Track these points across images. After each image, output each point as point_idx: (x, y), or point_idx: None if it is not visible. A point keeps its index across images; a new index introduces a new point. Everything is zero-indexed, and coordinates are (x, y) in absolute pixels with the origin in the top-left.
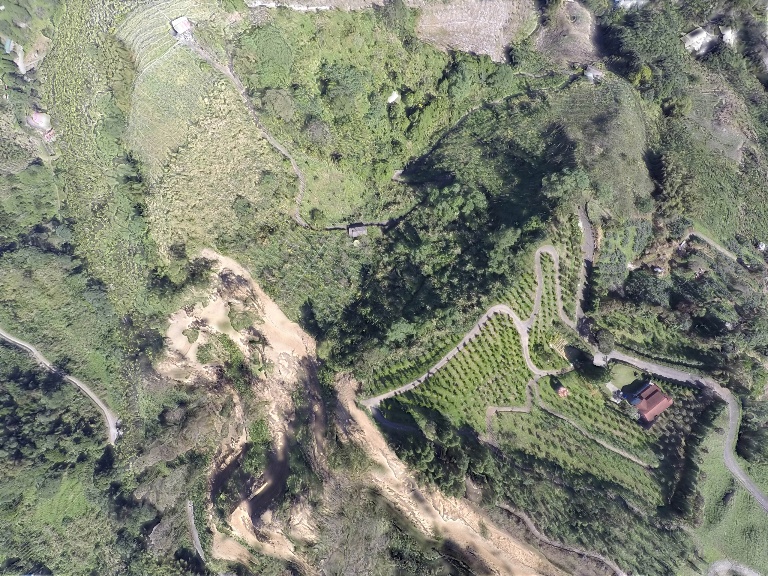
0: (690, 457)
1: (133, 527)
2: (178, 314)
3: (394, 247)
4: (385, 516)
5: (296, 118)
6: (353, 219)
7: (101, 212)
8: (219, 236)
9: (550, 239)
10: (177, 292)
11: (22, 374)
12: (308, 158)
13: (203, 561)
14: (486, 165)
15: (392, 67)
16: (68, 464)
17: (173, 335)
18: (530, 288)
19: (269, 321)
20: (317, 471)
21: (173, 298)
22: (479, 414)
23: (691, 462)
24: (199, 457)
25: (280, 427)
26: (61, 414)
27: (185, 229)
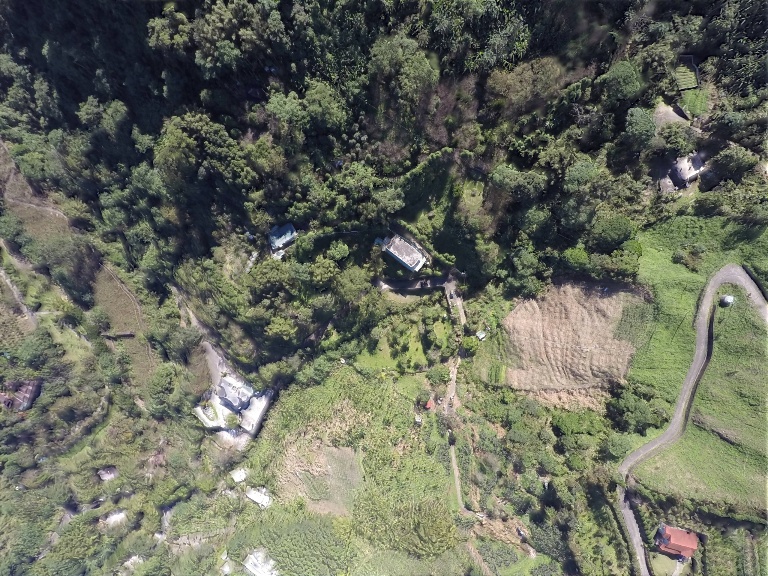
0: None
1: None
2: None
3: None
4: None
5: None
6: None
7: None
8: None
9: None
10: None
11: None
12: None
13: None
14: None
15: None
16: None
17: None
18: None
19: None
20: None
21: None
22: None
23: None
24: None
25: None
26: None
27: None
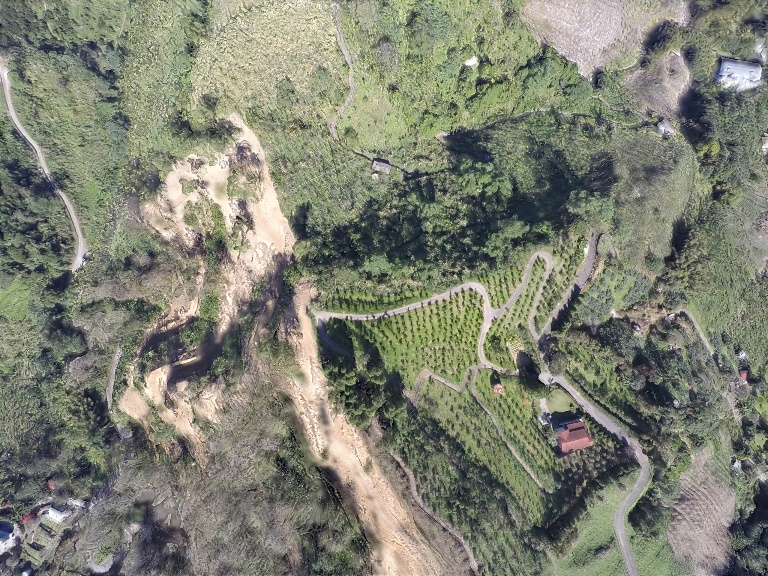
0: (584, 497)
1: (59, 351)
2: (184, 165)
3: (408, 195)
4: (287, 421)
5: (373, 32)
6: (382, 154)
7: (155, 48)
8: (252, 107)
9: (552, 248)
10: (191, 138)
11: (19, 169)
12: (367, 75)
13: (108, 409)
14: (527, 163)
15: (483, 32)
16: (25, 268)
17: (171, 183)
18: (513, 282)
19: (263, 207)
20: (245, 357)
21: (185, 141)
22: (413, 371)
23: (583, 501)
24: (146, 312)
25: (230, 311)
26: (38, 221)
27: (224, 84)
